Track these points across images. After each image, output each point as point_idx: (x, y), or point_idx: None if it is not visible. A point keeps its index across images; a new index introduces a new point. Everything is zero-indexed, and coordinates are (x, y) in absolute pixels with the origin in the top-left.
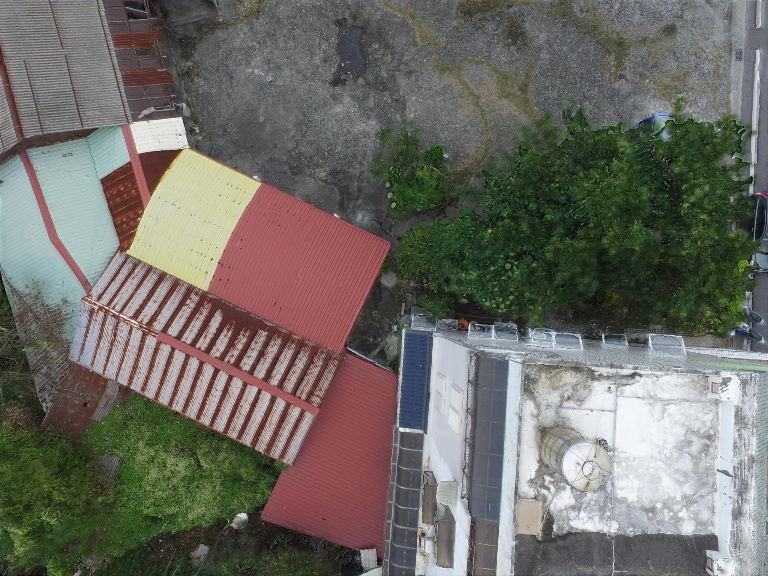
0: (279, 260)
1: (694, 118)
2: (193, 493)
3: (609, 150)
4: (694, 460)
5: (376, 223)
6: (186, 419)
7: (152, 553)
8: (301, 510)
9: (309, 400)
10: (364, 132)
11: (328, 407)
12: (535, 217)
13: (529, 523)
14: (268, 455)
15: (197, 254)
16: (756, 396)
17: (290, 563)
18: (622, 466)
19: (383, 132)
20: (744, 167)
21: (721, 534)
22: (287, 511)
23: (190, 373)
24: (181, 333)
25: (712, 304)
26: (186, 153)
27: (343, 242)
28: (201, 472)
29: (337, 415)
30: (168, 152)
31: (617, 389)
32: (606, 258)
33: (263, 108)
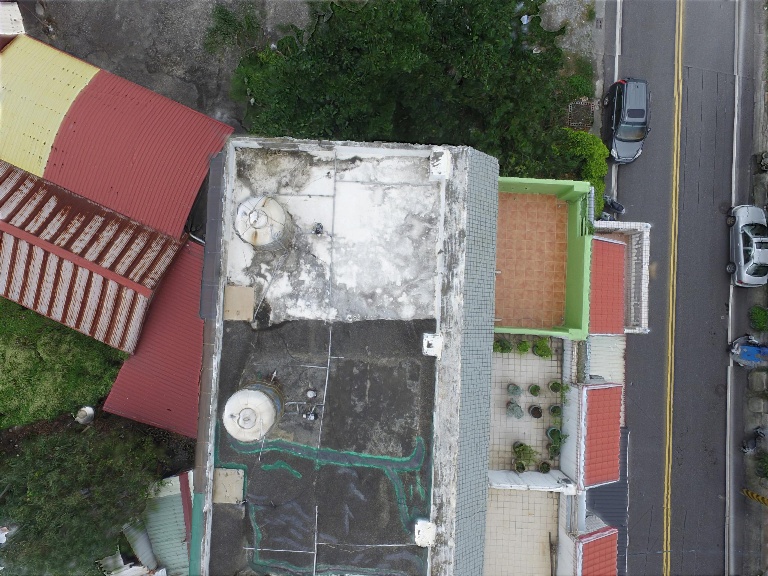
0: (114, 143)
1: (558, 10)
2: (34, 386)
3: (423, 5)
4: (414, 244)
5: (236, 121)
6: (32, 315)
7: (7, 458)
8: (145, 401)
9: (142, 282)
10: (223, 28)
11: (172, 296)
12: (336, 65)
13: (240, 309)
14: (108, 344)
15: (29, 138)
16: (468, 170)
17: (145, 462)
18: (340, 252)
19: (242, 28)
20: (609, 59)
21: (437, 315)
22: (130, 402)
23: (21, 258)
24: (10, 216)
25: (520, 153)
26: (21, 38)
27: (183, 126)
28: (44, 366)
29: (182, 304)
30: (0, 36)
31: (336, 174)
32: (407, 103)
33: (119, 5)
